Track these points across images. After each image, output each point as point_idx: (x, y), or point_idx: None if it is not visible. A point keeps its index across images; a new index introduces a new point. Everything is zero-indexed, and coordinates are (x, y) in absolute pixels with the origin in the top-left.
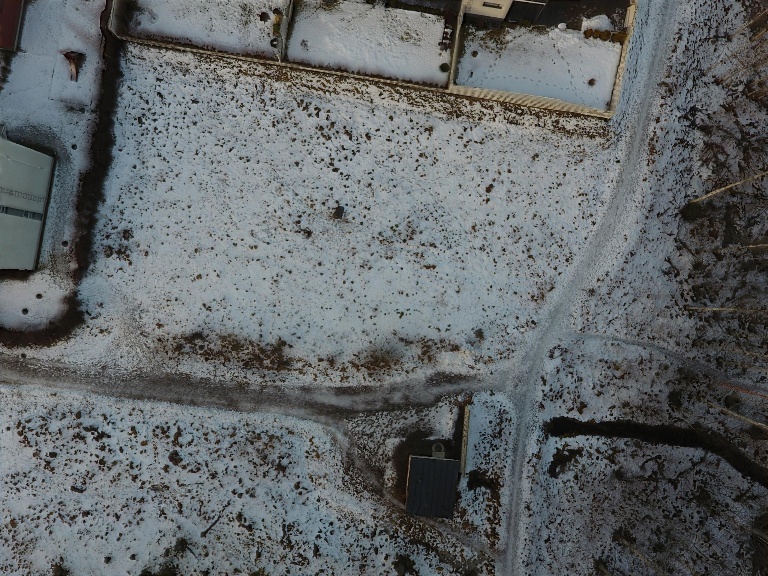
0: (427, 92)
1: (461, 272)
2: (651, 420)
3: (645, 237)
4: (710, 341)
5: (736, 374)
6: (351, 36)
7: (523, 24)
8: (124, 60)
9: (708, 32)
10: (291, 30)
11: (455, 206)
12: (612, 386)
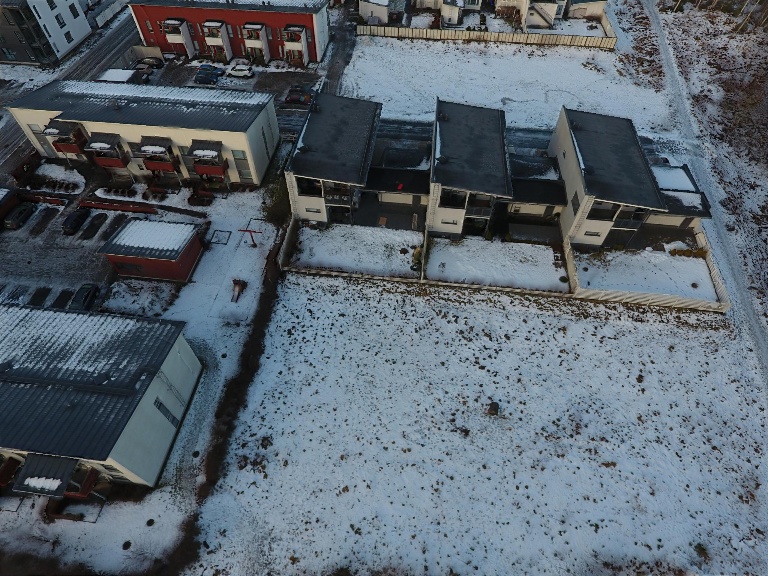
0: (554, 298)
1: (646, 469)
2: None
3: None
4: None
5: None
6: (478, 261)
7: (617, 249)
8: (280, 286)
9: (761, 255)
10: (427, 259)
11: (612, 398)
12: None
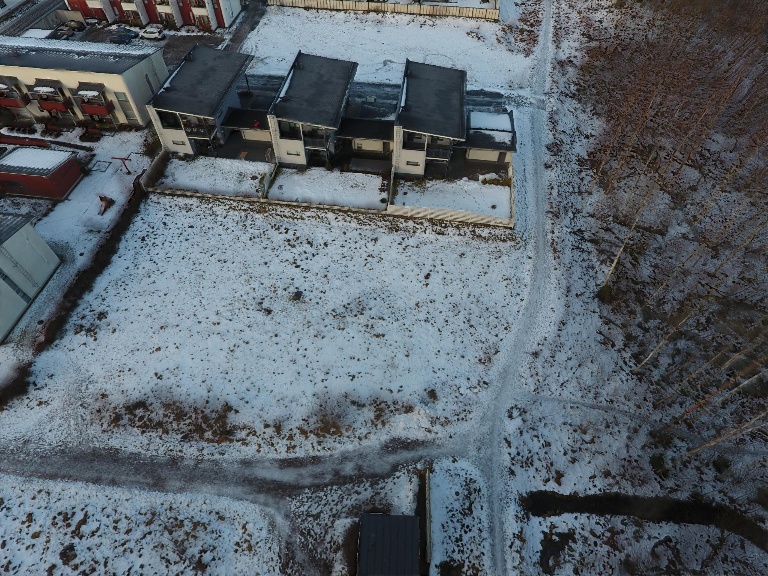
0: (371, 215)
1: (409, 339)
2: (641, 491)
3: (571, 311)
4: (670, 403)
5: (712, 436)
6: (315, 186)
7: (437, 178)
8: (144, 204)
9: (573, 189)
10: (272, 184)
11: (399, 290)
12: (585, 452)
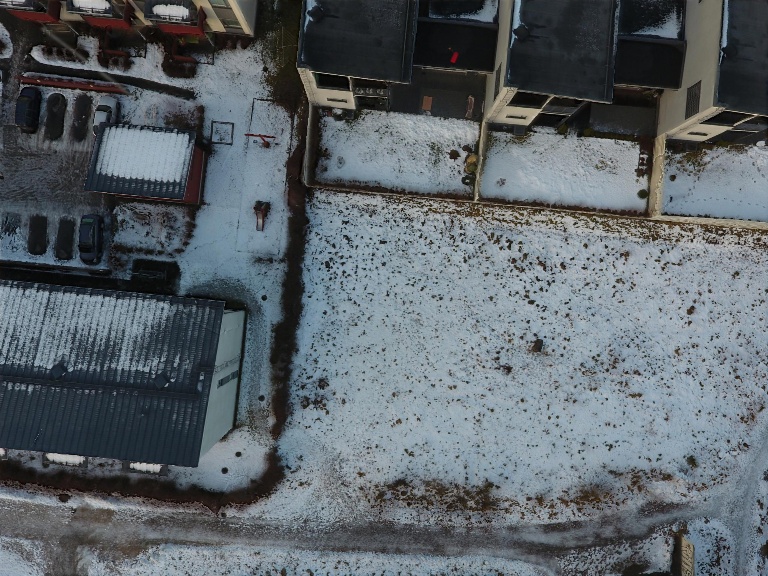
0: (625, 219)
1: (668, 398)
2: None
3: None
4: None
5: None
6: (544, 168)
7: (721, 145)
8: (309, 205)
9: None
10: (482, 166)
11: (656, 331)
12: None
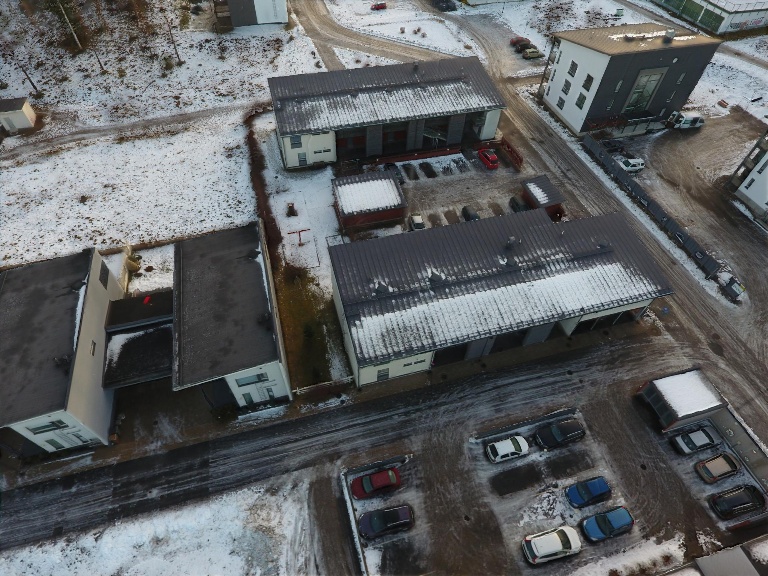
0: None
1: None
2: None
3: None
4: None
5: None
6: None
7: None
8: None
9: None
10: None
11: None
12: None
